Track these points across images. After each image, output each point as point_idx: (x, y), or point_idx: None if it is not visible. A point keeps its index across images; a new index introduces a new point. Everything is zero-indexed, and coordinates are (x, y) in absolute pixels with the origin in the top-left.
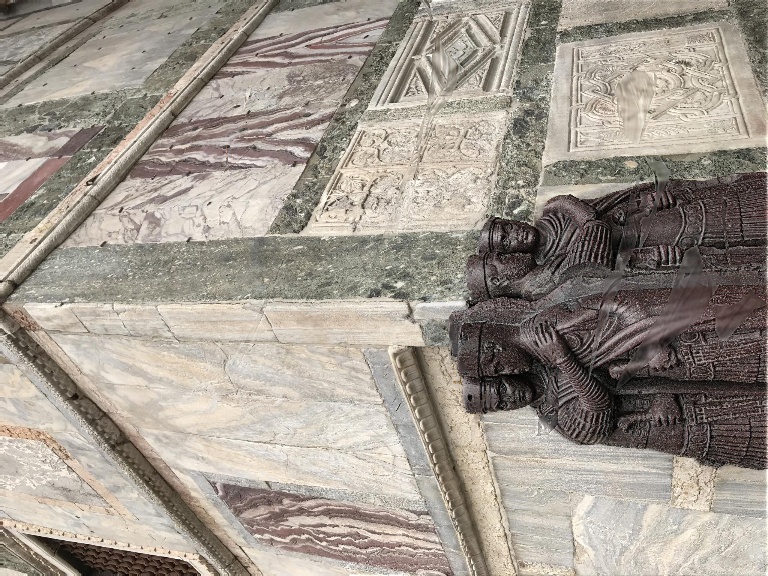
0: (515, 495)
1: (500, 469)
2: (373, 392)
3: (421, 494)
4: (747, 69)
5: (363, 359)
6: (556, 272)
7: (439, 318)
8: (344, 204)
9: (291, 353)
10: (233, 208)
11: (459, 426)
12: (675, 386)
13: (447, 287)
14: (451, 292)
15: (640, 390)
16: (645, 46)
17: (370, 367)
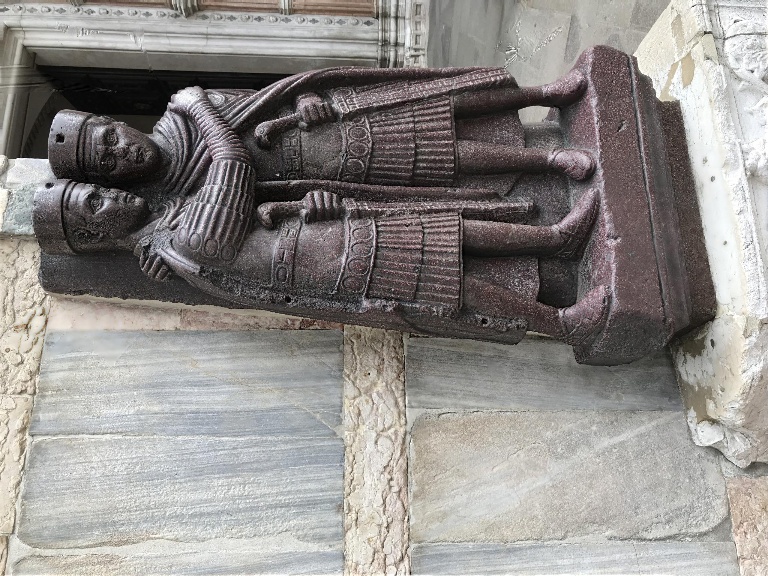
0: None
1: None
2: None
3: None
4: None
5: None
6: None
7: None
8: None
9: None
10: None
11: None
12: None
13: None
14: None
15: (290, 181)
16: None
17: None
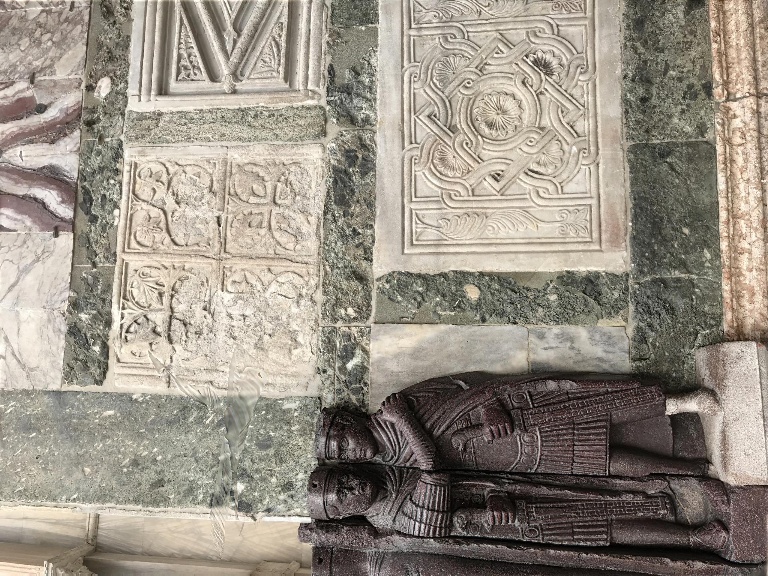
0: None
1: None
2: None
3: None
4: (616, 95)
5: None
6: (397, 519)
7: None
8: (145, 332)
9: None
10: (1, 324)
11: None
12: None
13: (289, 496)
14: (294, 502)
15: None
16: (497, 8)
17: None
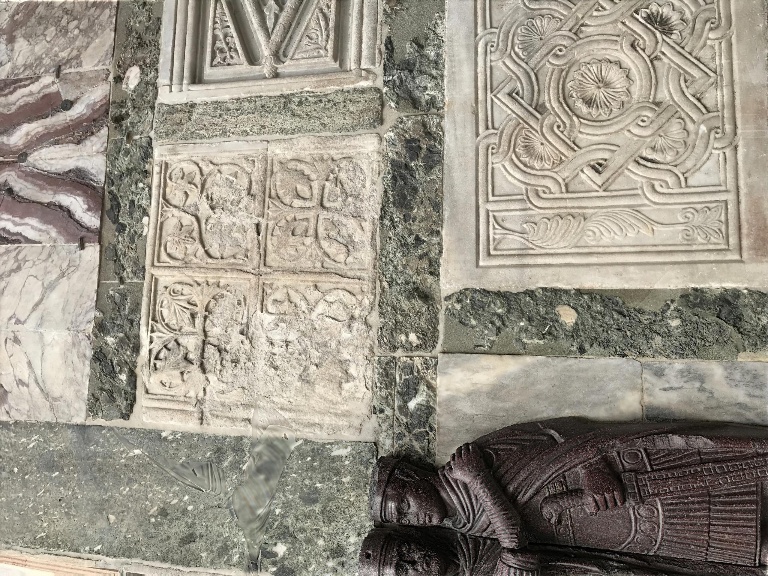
0: None
1: None
2: None
3: None
4: (760, 55)
5: None
6: None
7: None
8: (175, 359)
9: None
10: (24, 348)
11: None
12: None
13: (339, 562)
14: (345, 570)
15: None
16: None
17: None
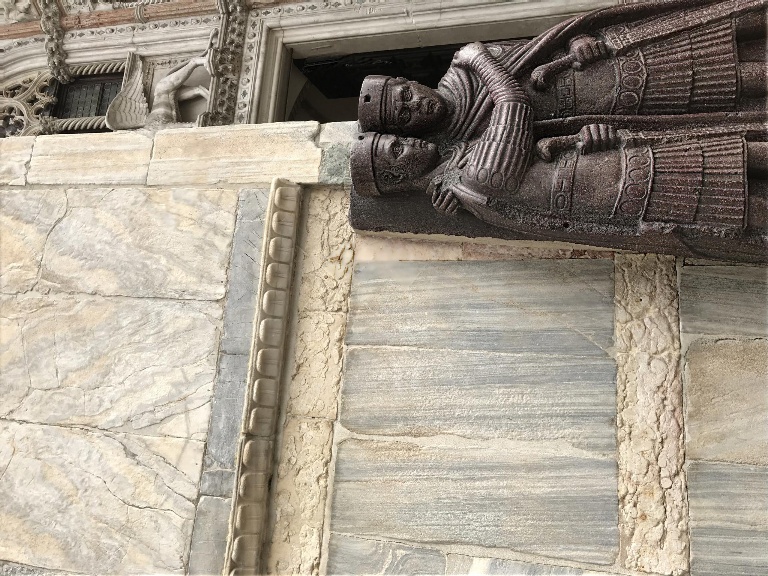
0: (352, 572)
1: (344, 481)
2: (220, 273)
3: (187, 570)
4: None
5: (234, 207)
6: None
7: (347, 141)
8: None
9: (150, 203)
10: None
11: (311, 361)
12: None
13: None
14: None
15: (565, 118)
16: None
17: (237, 221)
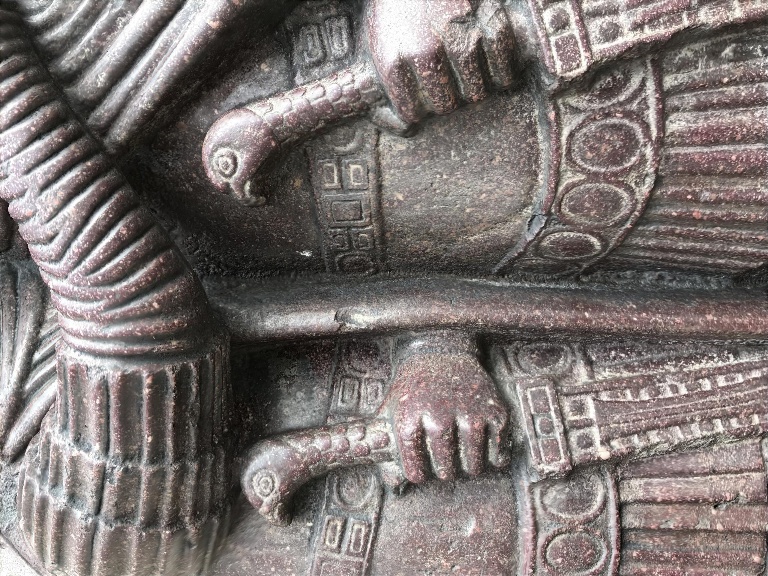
0: None
1: None
2: None
3: None
4: None
5: None
6: None
7: None
8: None
9: None
10: None
11: None
12: (482, 294)
13: None
14: None
15: (345, 310)
16: None
17: None
